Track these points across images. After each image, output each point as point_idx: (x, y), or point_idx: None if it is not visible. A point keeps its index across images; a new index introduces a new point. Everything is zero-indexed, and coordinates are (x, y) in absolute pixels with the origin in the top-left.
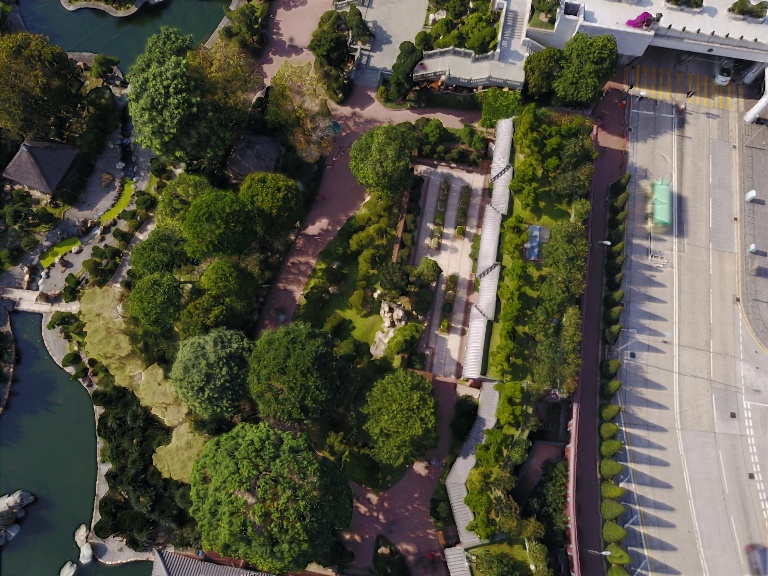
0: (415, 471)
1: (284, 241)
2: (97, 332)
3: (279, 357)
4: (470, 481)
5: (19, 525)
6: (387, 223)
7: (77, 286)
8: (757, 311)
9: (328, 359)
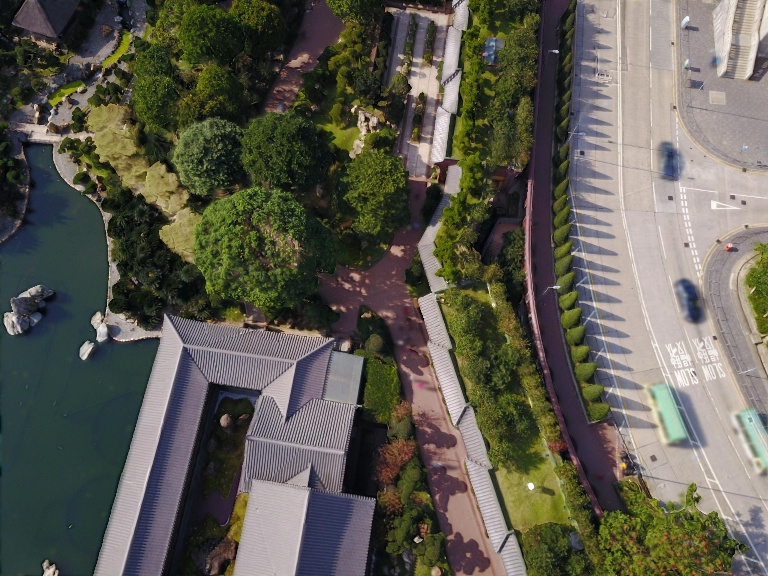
0: (392, 253)
1: (270, 71)
2: (105, 137)
3: (268, 129)
4: (438, 237)
5: (41, 314)
6: (361, 49)
7: (84, 118)
8: (691, 116)
9: (311, 134)
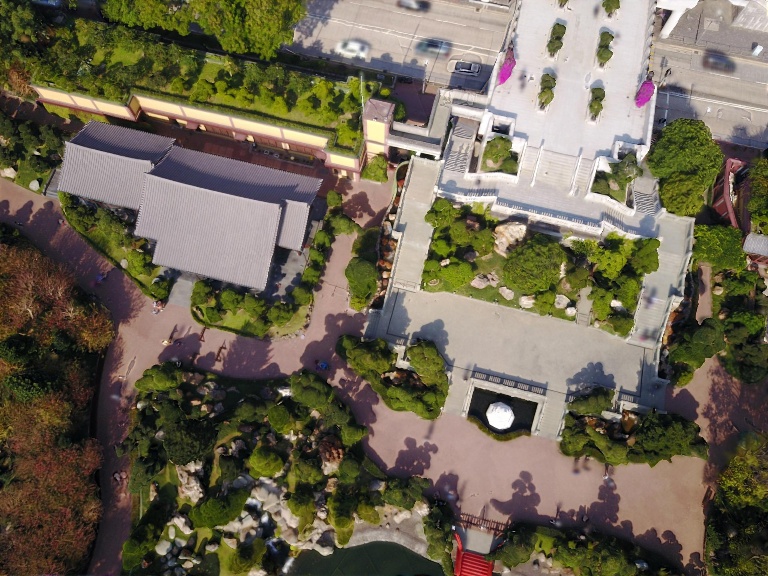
0: None
1: None
2: None
3: None
4: None
5: None
6: None
7: None
8: None
9: None
